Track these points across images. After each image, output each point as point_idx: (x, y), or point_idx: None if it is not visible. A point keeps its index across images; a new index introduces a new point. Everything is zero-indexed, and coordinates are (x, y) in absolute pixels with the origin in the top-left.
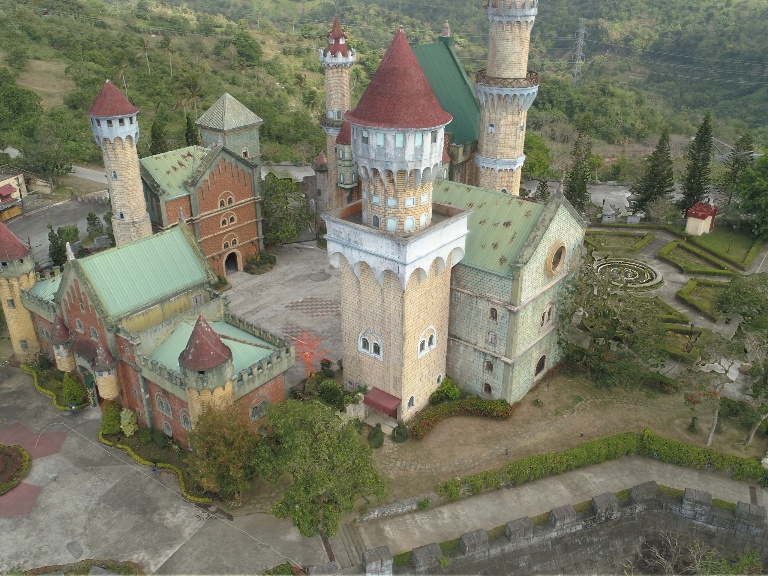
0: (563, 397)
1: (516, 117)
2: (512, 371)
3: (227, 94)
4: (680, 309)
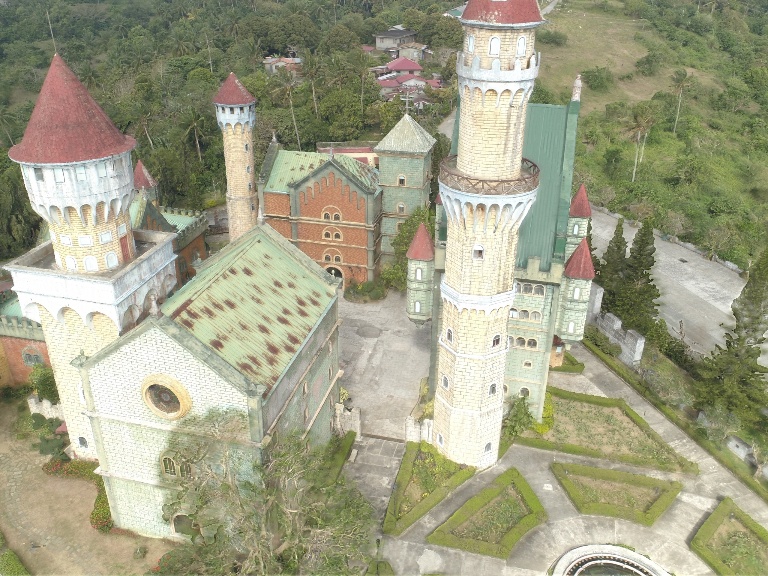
0: None
1: (463, 232)
2: (110, 486)
3: (406, 115)
4: None
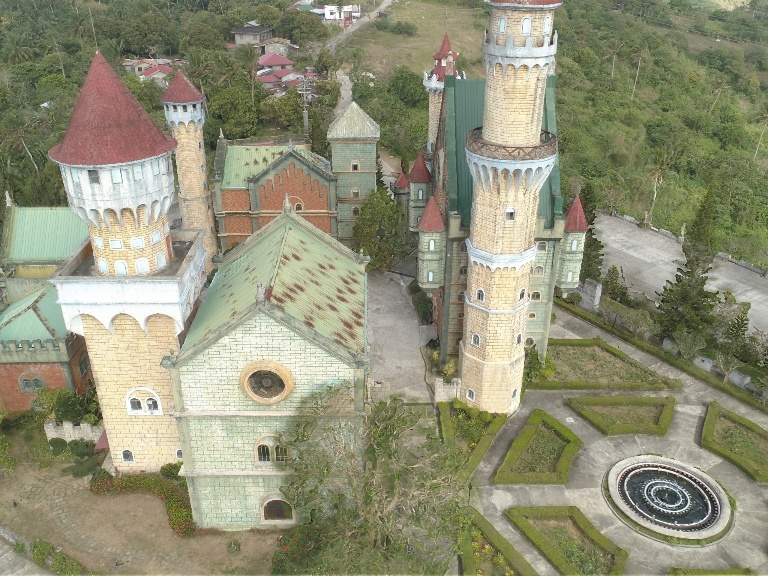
0: (270, 563)
1: (495, 197)
2: (194, 486)
3: (354, 103)
4: None
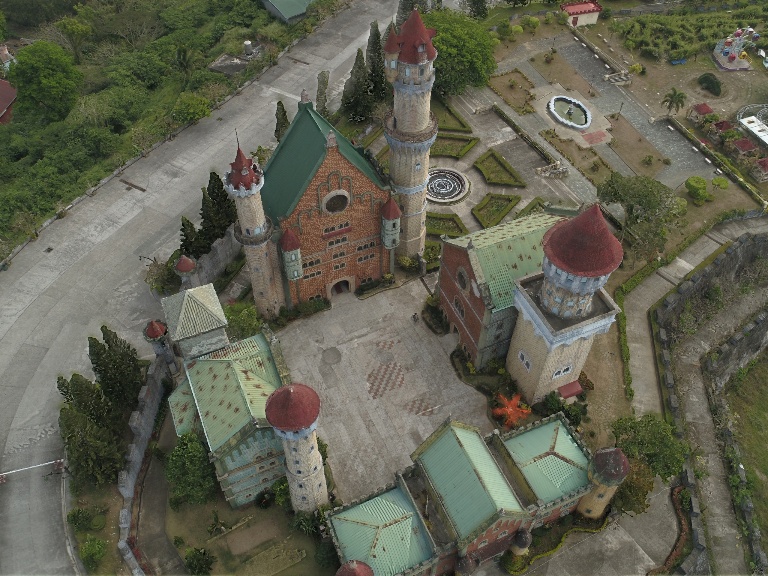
0: None
1: None
2: None
3: (188, 291)
4: (501, 191)
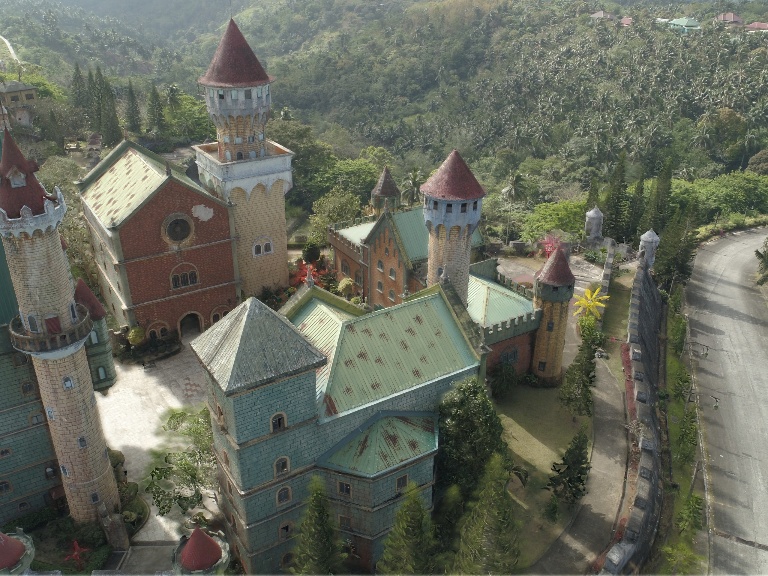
0: None
1: None
2: None
3: (253, 298)
4: None
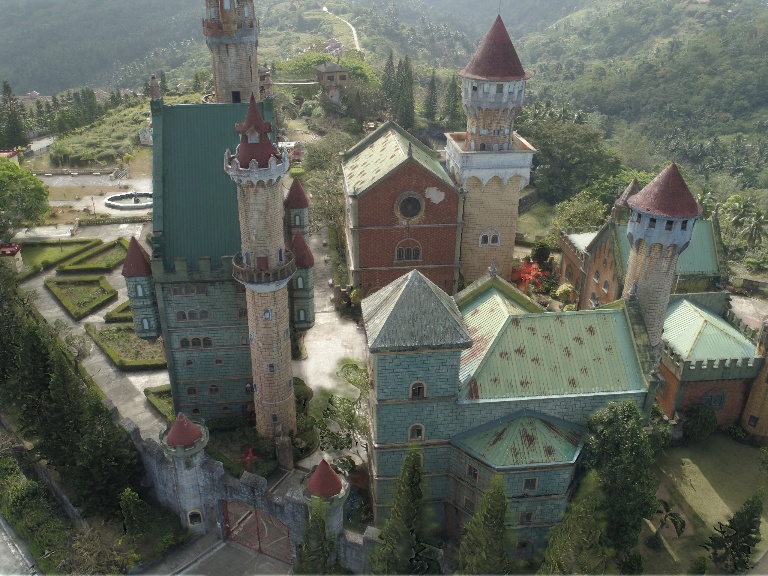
0: None
1: None
2: None
3: (416, 271)
4: None
